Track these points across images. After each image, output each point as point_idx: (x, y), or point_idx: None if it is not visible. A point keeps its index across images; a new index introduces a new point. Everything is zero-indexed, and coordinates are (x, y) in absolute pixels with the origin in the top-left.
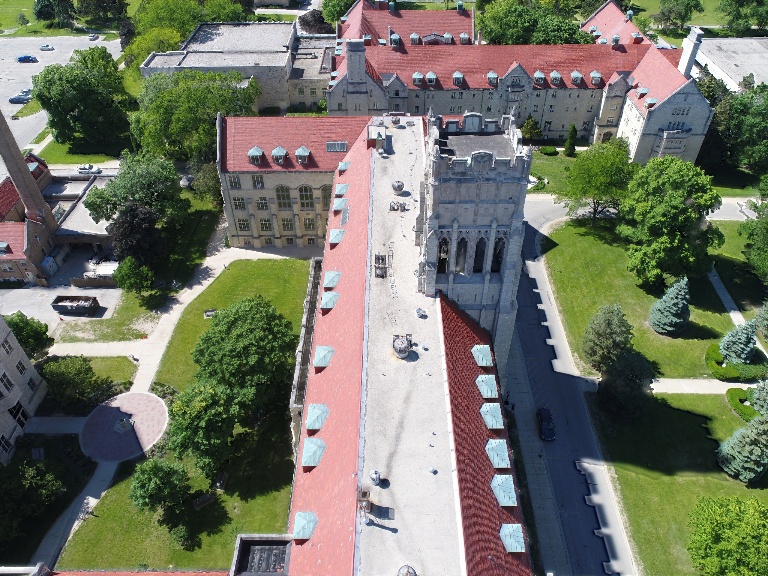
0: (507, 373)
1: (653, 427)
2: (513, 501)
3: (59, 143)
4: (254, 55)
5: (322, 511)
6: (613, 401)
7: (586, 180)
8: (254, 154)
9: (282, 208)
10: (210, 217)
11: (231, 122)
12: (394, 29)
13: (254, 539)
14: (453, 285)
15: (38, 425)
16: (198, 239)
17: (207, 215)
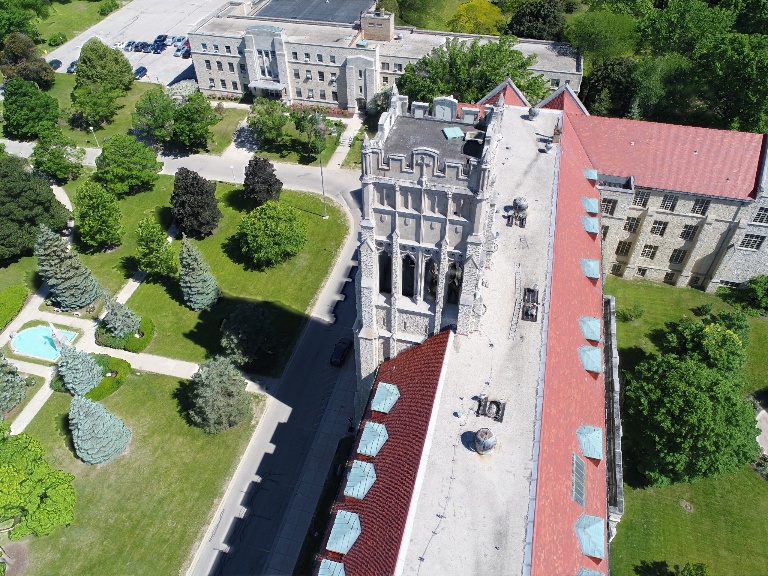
0: None
1: None
2: None
3: None
4: None
5: None
6: None
7: None
8: None
9: None
10: None
11: None
12: None
13: None
14: None
15: None
16: None
17: None
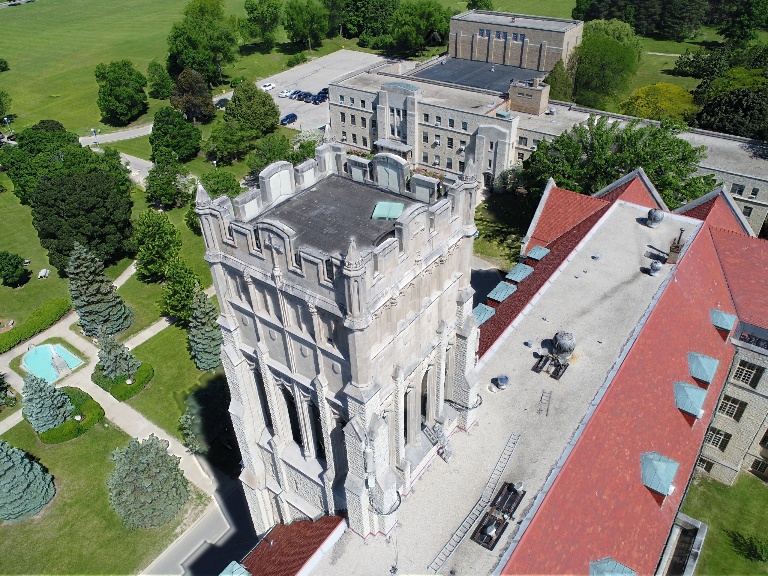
0: None
1: None
2: None
3: None
4: None
5: None
6: None
7: None
8: None
9: None
10: None
11: None
12: None
13: None
14: None
15: None
16: None
17: None
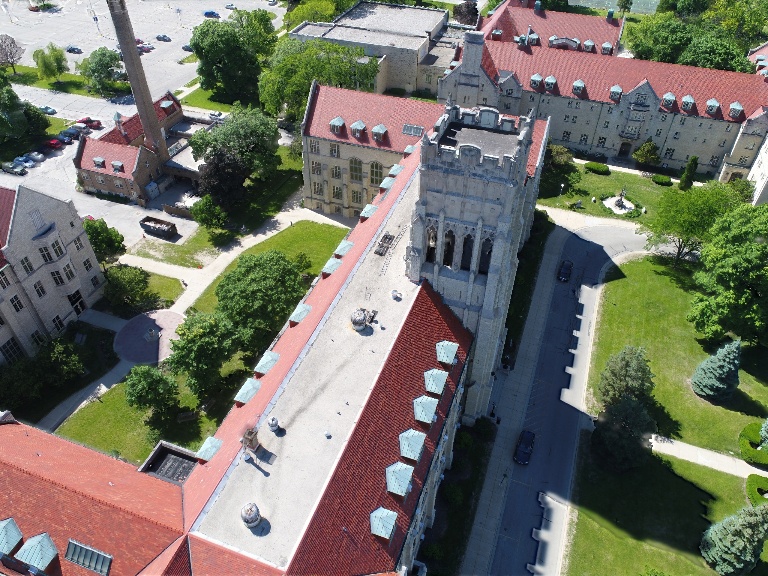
0: (492, 383)
1: (642, 486)
2: (402, 490)
3: (203, 89)
4: (394, 36)
5: (227, 441)
6: (603, 445)
7: (671, 214)
8: (335, 123)
9: (353, 180)
10: (299, 177)
11: (323, 90)
12: (535, 29)
13: (171, 448)
14: (439, 277)
15: (90, 316)
16: (280, 194)
17: (297, 175)
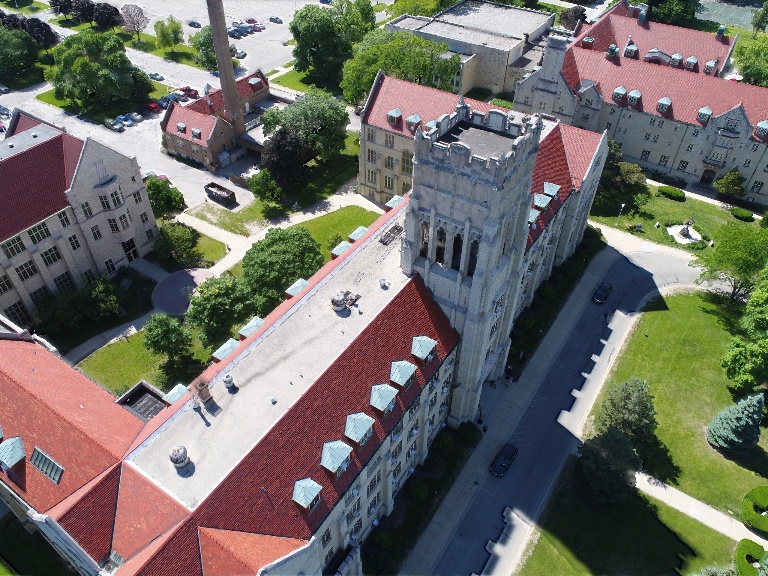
0: (478, 388)
1: (618, 524)
2: (333, 467)
3: (296, 71)
4: (489, 35)
5: None
6: None
7: (726, 250)
8: (392, 114)
9: (405, 172)
10: None
11: (387, 81)
12: (635, 40)
13: (149, 388)
14: (430, 272)
15: (140, 265)
16: (339, 178)
17: None
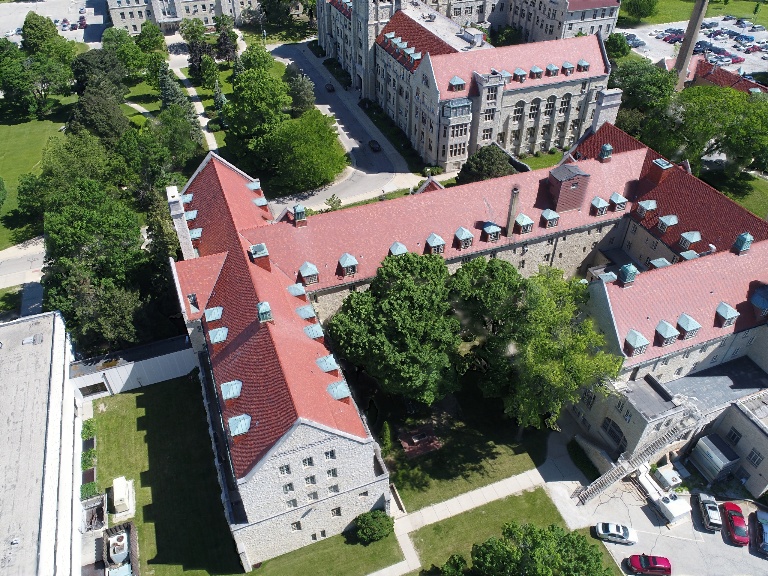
0: None
1: None
2: None
3: None
4: None
5: None
6: None
7: None
8: None
9: None
10: None
11: None
12: None
13: None
14: None
15: None
16: None
17: None
